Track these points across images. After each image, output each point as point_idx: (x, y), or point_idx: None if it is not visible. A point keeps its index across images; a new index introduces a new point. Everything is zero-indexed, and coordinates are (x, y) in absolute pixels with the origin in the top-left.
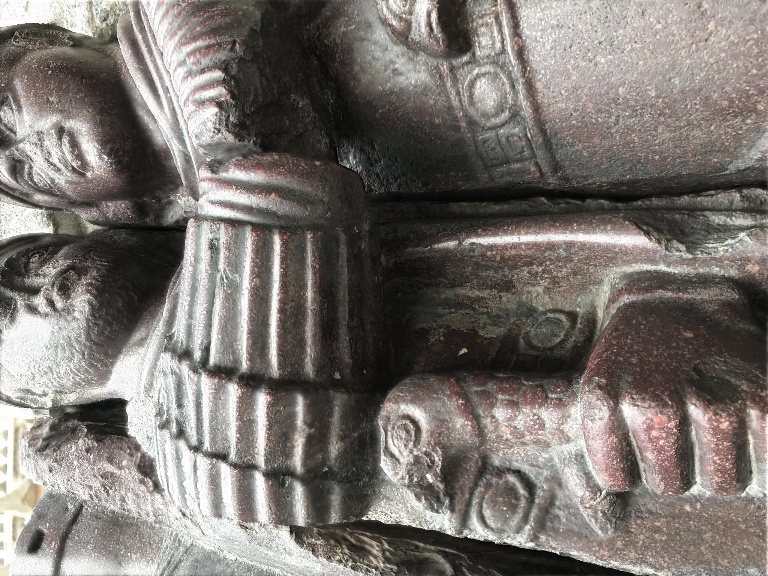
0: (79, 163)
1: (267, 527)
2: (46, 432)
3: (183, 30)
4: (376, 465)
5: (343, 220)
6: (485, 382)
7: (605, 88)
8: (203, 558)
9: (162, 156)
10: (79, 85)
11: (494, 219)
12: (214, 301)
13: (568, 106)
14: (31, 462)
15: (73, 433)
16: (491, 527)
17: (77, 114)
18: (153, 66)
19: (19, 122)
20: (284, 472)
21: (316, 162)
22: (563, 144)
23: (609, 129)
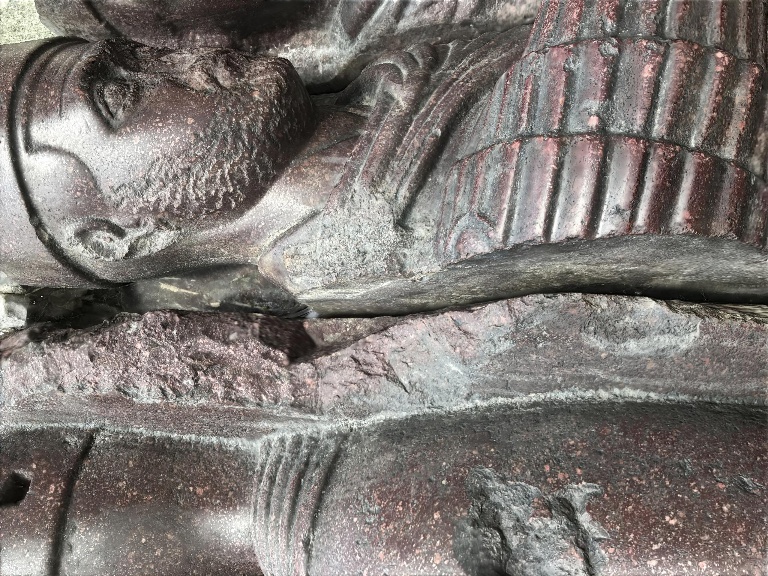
0: None
1: (619, 300)
2: (24, 341)
3: None
4: None
5: None
6: None
7: None
8: (404, 424)
9: None
10: None
11: None
12: None
13: None
14: (33, 361)
15: (112, 319)
16: None
17: None
18: None
19: None
20: None
21: None
22: None
23: None
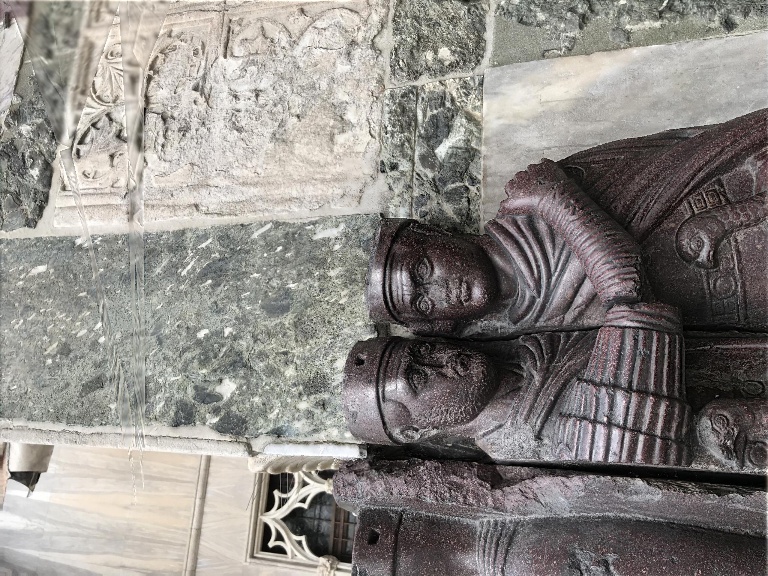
0: (467, 298)
1: (627, 480)
2: (368, 467)
3: (610, 249)
4: (693, 443)
5: (682, 332)
6: (752, 400)
7: None
8: (543, 521)
9: (502, 297)
10: (472, 258)
11: (723, 338)
12: (636, 362)
13: (759, 293)
14: (379, 481)
15: (410, 462)
16: (756, 464)
17: (473, 273)
18: (532, 254)
19: (430, 273)
20: (667, 438)
21: (676, 307)
22: (753, 308)
23: None
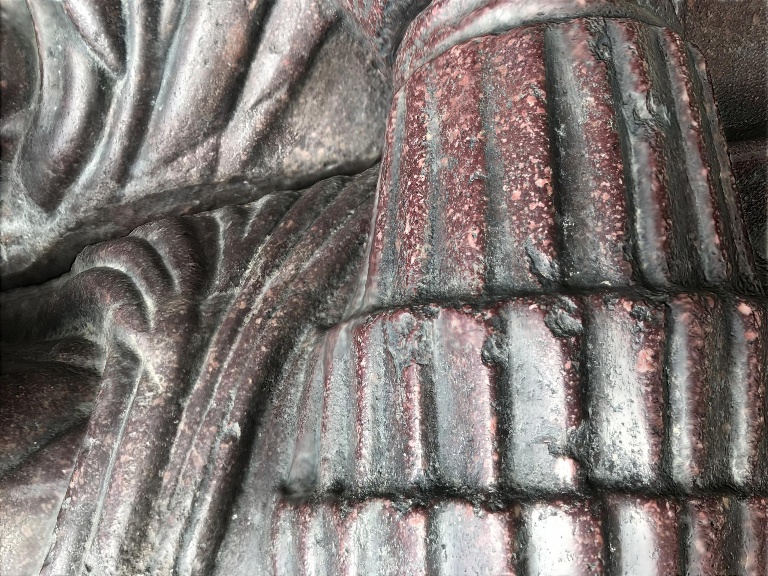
0: None
1: None
2: None
3: None
4: None
5: None
6: None
7: (744, 13)
8: None
9: None
10: None
11: None
12: (632, 158)
13: (709, 30)
14: None
15: None
16: None
17: None
18: None
19: None
20: None
21: None
22: None
23: (733, 62)
